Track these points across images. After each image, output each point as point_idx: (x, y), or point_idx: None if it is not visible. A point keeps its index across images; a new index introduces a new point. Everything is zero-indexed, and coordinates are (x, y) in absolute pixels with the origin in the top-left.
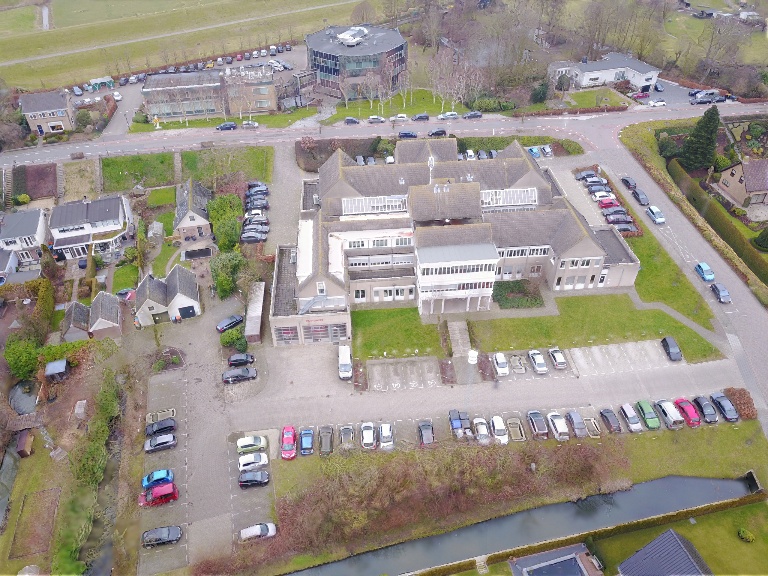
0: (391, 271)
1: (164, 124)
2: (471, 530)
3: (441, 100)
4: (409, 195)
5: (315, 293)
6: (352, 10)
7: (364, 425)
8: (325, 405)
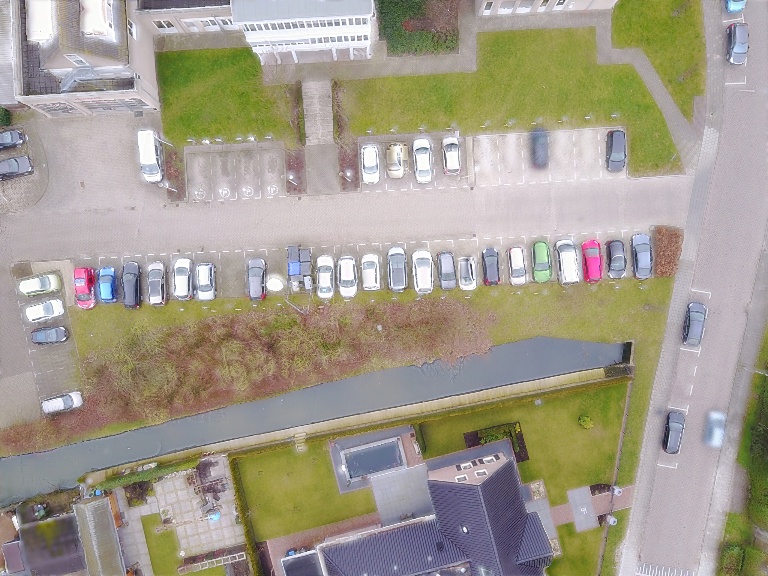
0: None
1: None
2: (299, 394)
3: None
4: None
5: (71, 64)
6: None
7: (178, 265)
8: (130, 223)
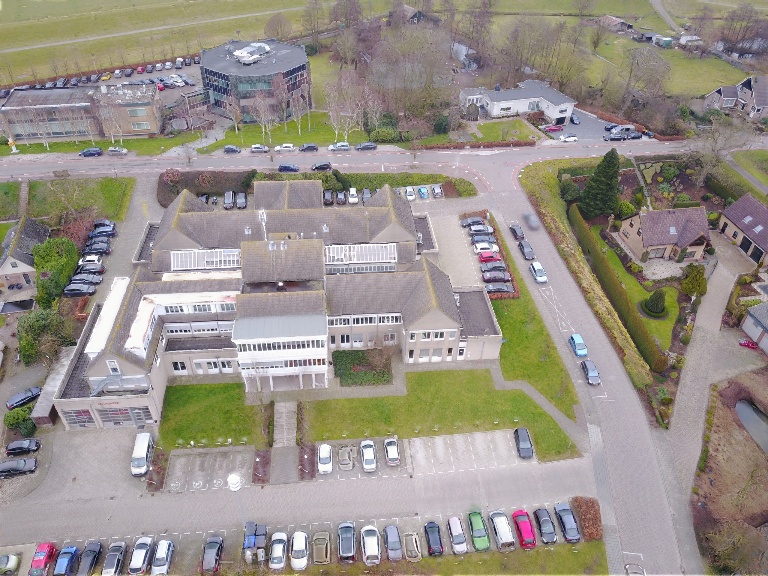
0: (218, 339)
1: (25, 147)
2: None
3: (334, 128)
4: (240, 252)
5: (108, 372)
6: (266, 22)
7: (139, 541)
8: (105, 510)
